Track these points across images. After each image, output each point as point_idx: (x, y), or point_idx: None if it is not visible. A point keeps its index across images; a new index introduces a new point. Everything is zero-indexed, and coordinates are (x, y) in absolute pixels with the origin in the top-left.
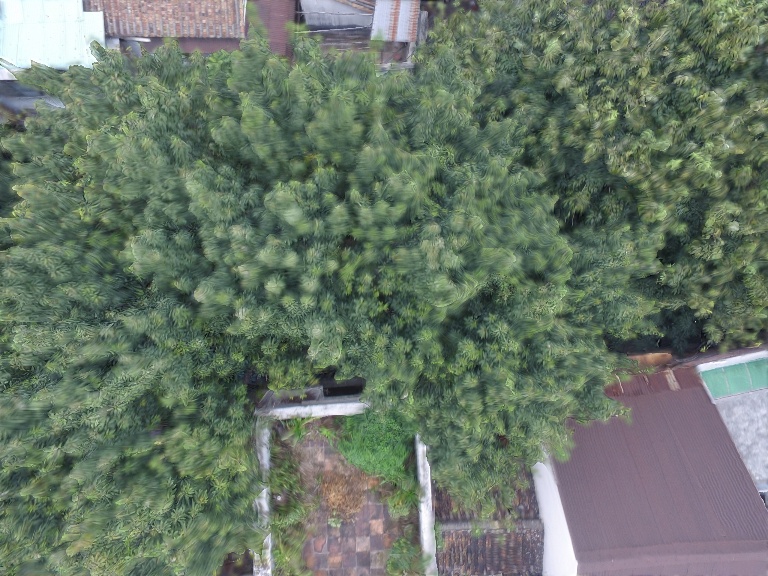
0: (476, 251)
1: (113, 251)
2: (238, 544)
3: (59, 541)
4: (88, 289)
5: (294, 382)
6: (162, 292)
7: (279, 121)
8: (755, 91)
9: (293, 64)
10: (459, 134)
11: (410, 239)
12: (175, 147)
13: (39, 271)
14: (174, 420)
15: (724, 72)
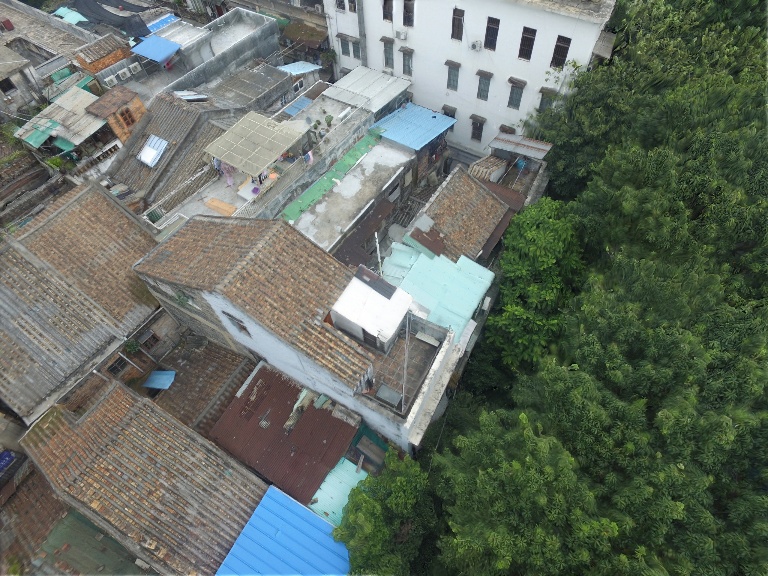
0: None
1: None
2: None
3: None
4: None
5: None
6: None
7: None
8: (697, 32)
9: None
10: None
11: None
12: None
13: None
14: None
15: None
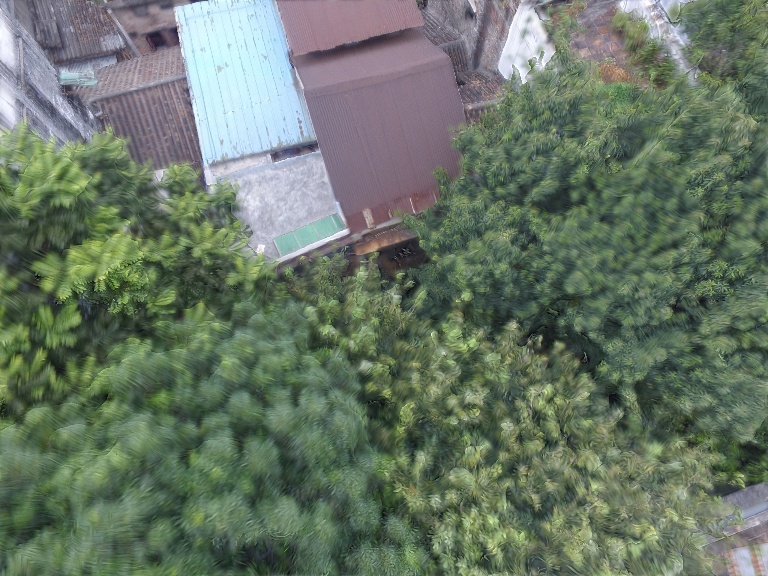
0: None
1: None
2: (699, 3)
3: None
4: None
5: None
6: None
7: None
8: (403, 455)
9: None
10: None
11: (743, 154)
12: None
13: None
14: None
15: None
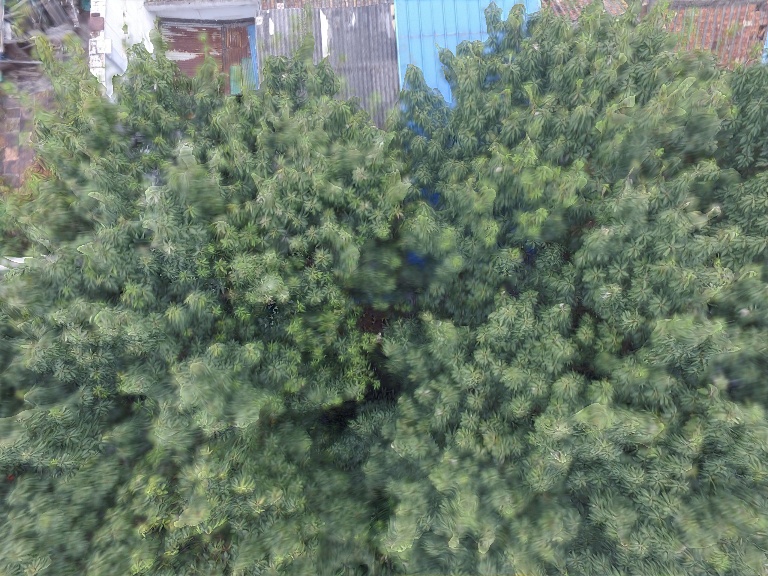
0: None
1: None
2: None
3: (213, 121)
4: None
5: None
6: (71, 384)
7: None
8: None
9: None
10: None
11: None
12: None
13: (177, 406)
14: (74, 239)
15: None
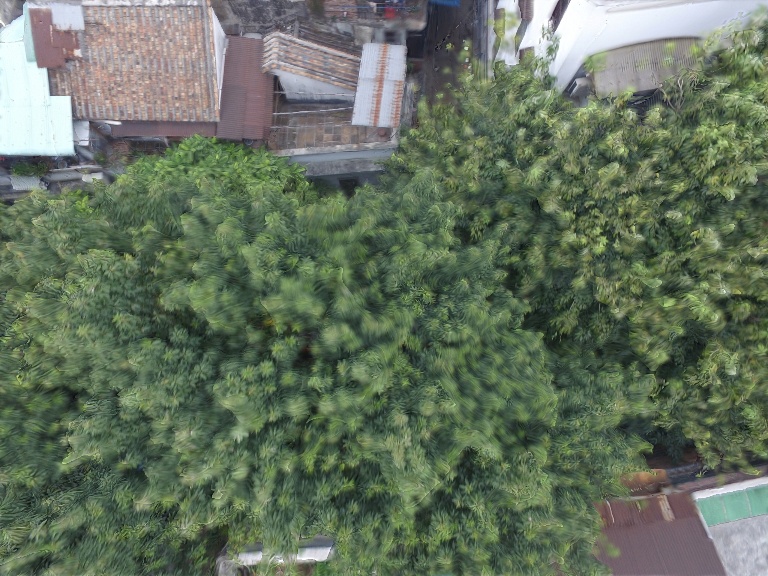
0: (449, 427)
1: (57, 410)
2: None
3: None
4: (23, 471)
5: (257, 538)
6: (107, 464)
7: (235, 281)
8: (753, 221)
9: (244, 244)
10: (437, 263)
11: (376, 416)
12: (117, 321)
13: None
14: None
15: (720, 196)
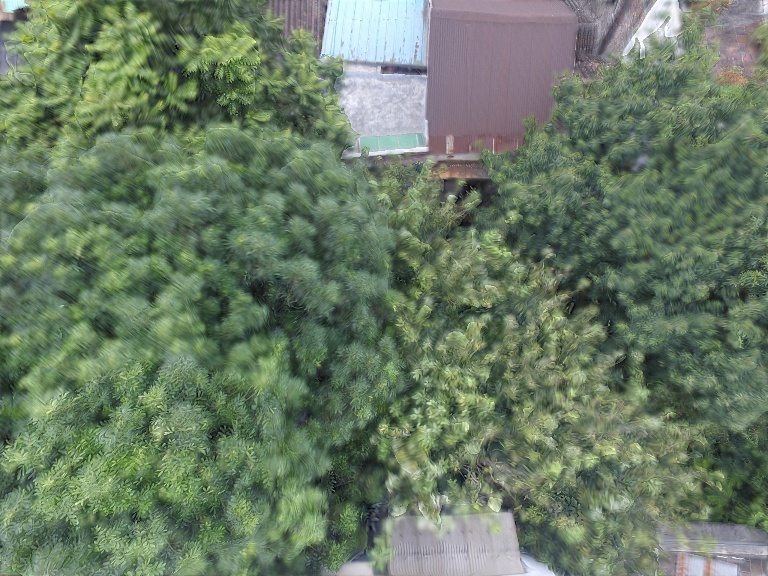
0: None
1: None
2: None
3: None
4: None
5: None
6: None
7: None
8: None
9: None
10: None
11: None
12: None
13: None
14: None
15: None
